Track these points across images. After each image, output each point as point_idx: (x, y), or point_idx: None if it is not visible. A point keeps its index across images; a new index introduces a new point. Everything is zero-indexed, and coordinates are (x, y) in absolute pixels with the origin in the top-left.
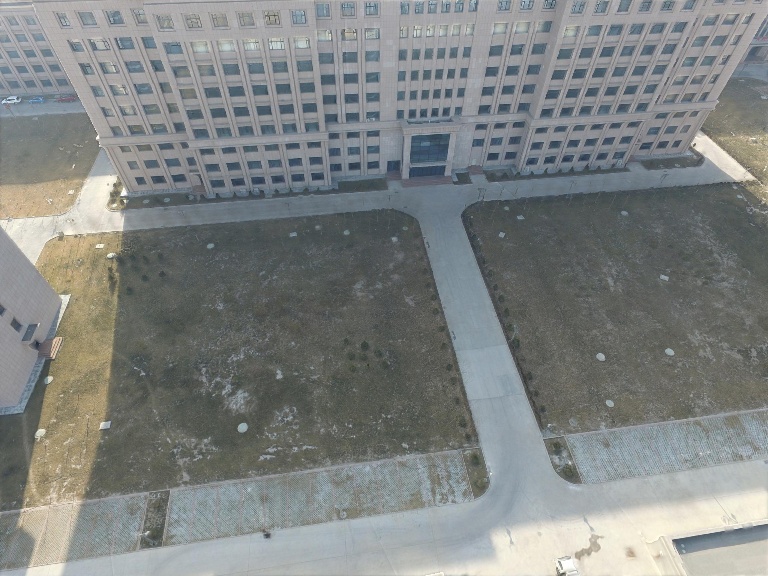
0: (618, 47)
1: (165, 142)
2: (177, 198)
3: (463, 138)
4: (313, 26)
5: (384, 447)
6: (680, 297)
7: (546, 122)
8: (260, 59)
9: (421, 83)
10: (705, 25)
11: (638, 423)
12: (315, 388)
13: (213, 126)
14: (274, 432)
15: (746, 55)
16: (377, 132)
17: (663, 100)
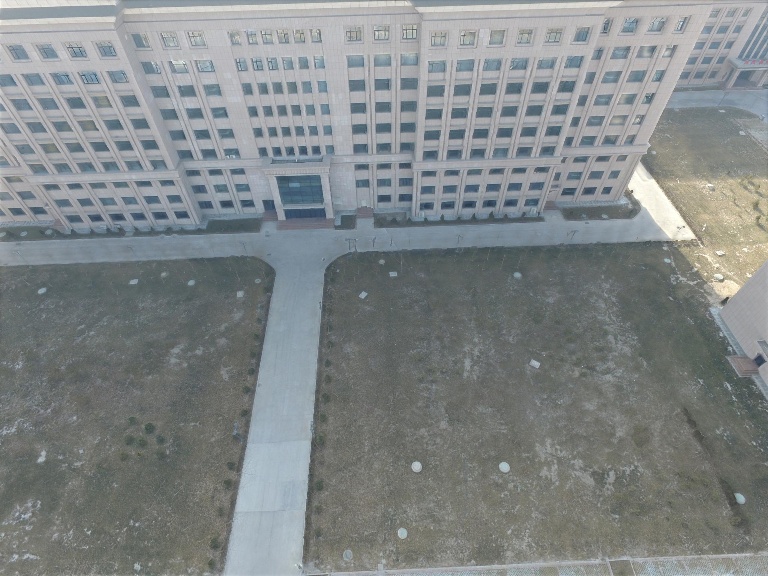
0: (500, 84)
1: (10, 175)
2: (35, 232)
3: (343, 178)
4: (124, 59)
5: (113, 566)
6: (545, 391)
7: (431, 165)
8: (76, 93)
9: (277, 119)
10: (615, 58)
11: (427, 565)
12: (72, 478)
13: (48, 161)
14: (3, 532)
15: (734, 80)
16: (242, 170)
17: (578, 142)
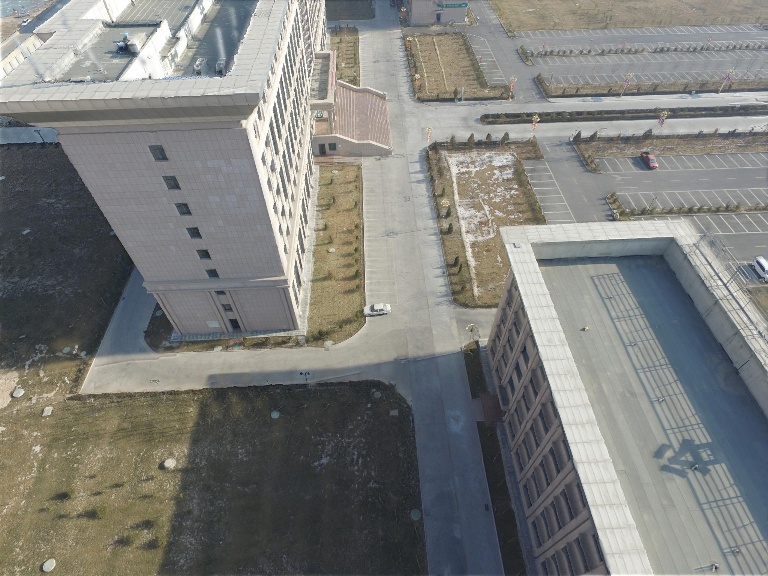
0: None
1: None
2: None
3: None
4: None
5: None
6: (3, 234)
7: None
8: None
9: None
10: None
11: None
12: None
13: None
14: None
15: None
16: None
17: None
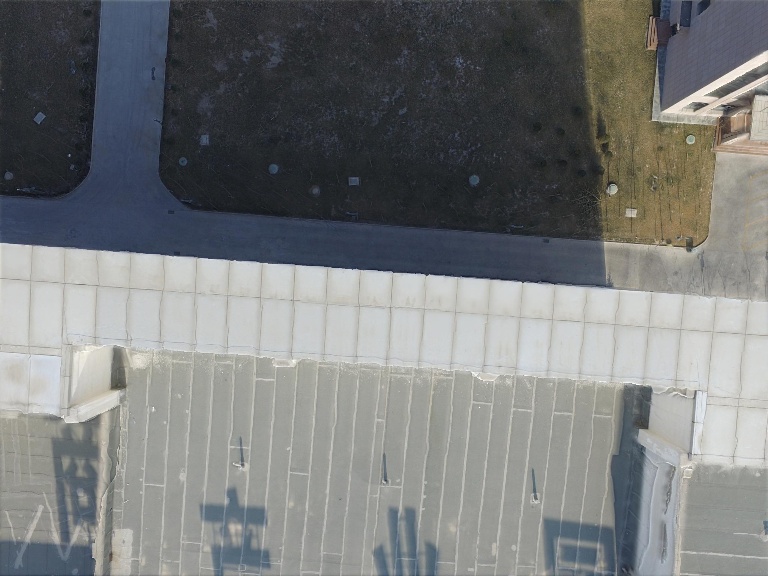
0: None
1: None
2: None
3: None
4: None
5: None
6: None
7: None
8: None
9: None
10: None
11: None
12: None
13: None
14: None
15: None
16: None
17: None
